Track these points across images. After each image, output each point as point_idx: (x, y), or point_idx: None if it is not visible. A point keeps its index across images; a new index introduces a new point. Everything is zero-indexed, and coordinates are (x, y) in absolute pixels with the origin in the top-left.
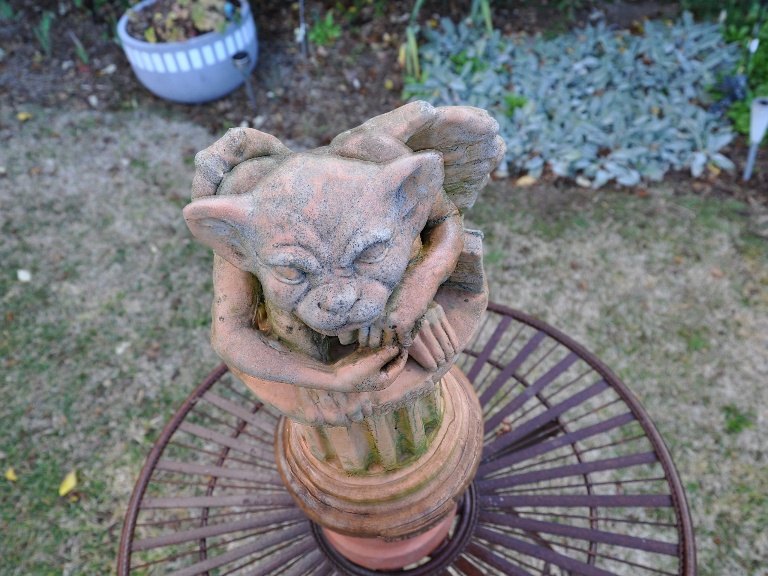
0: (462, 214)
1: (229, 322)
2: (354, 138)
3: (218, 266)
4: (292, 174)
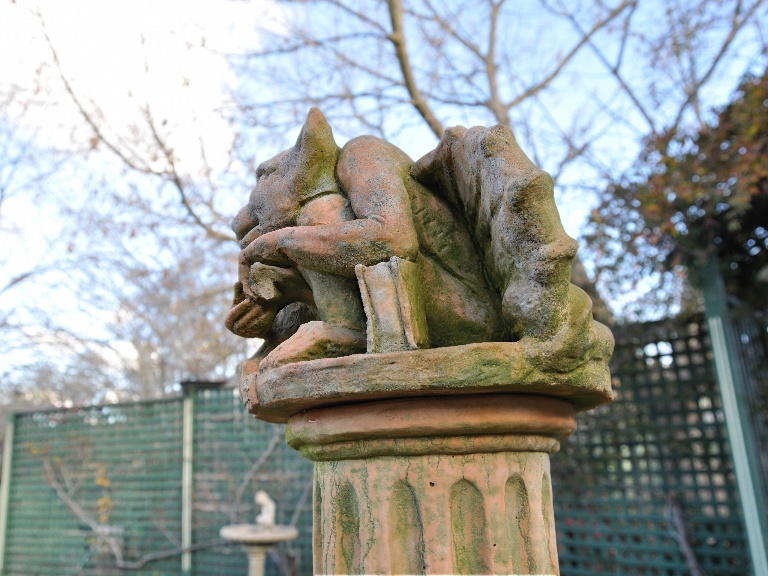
0: (532, 331)
1: None
2: None
3: None
4: None
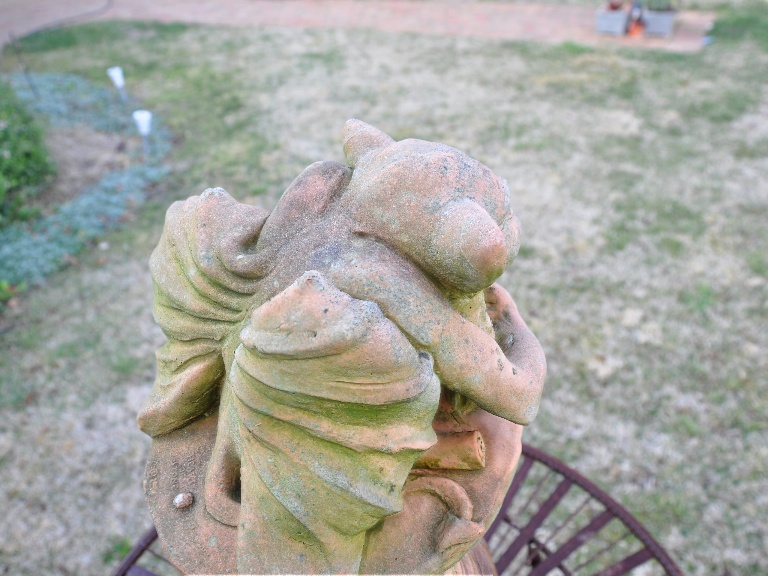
0: None
1: (513, 365)
2: (315, 185)
3: (471, 348)
4: (433, 152)
